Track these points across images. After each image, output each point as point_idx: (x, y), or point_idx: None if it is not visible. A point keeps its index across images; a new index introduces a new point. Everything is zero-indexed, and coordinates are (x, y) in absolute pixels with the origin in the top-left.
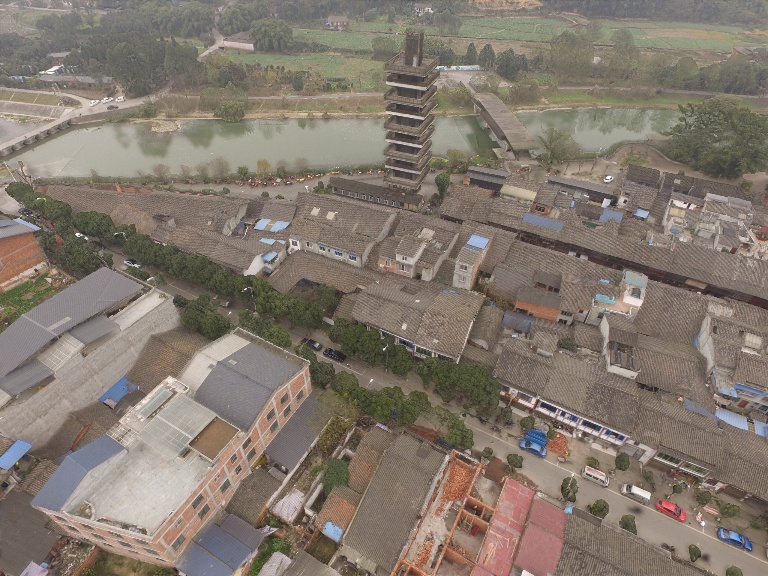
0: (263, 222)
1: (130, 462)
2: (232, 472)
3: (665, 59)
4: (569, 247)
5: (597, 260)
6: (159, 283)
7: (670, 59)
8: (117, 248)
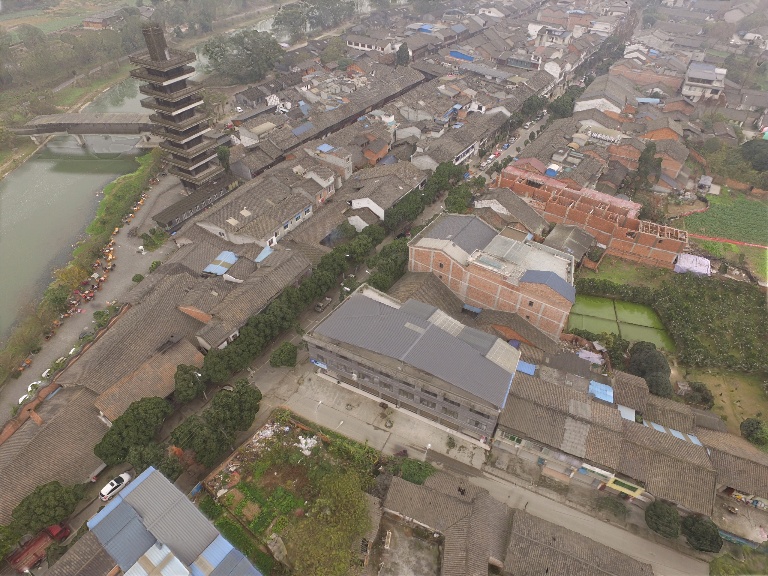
0: (213, 268)
1: None
2: None
3: (95, 36)
4: (323, 133)
5: (334, 131)
6: None
7: (98, 35)
8: (170, 427)
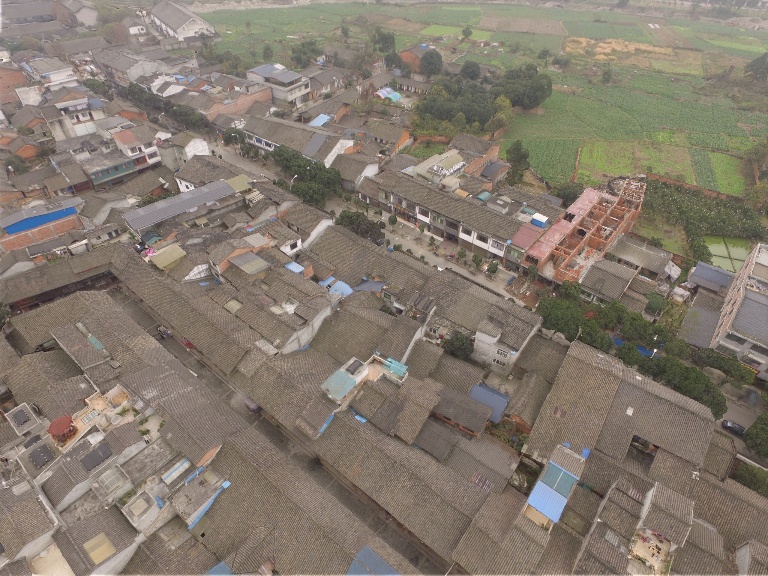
0: None
1: None
2: None
3: None
4: None
5: None
6: None
7: None
8: None
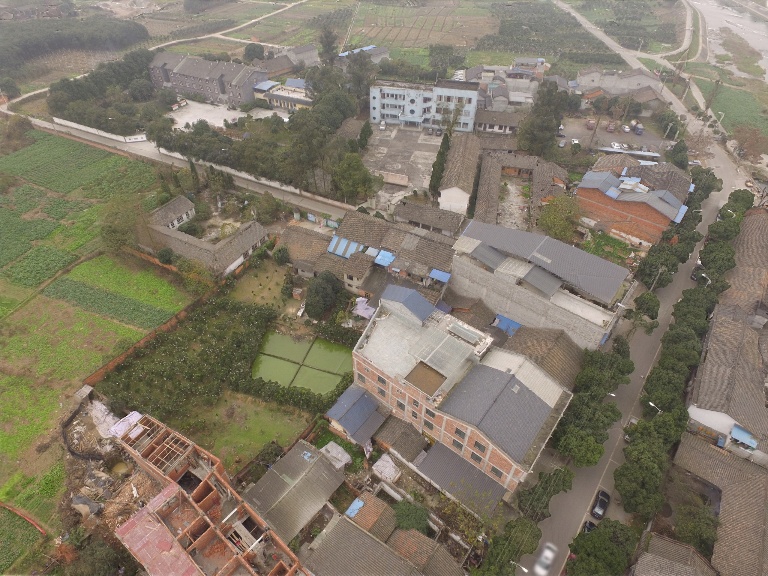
0: None
1: (418, 331)
2: (410, 408)
3: None
4: None
5: None
6: (645, 326)
7: None
8: None
